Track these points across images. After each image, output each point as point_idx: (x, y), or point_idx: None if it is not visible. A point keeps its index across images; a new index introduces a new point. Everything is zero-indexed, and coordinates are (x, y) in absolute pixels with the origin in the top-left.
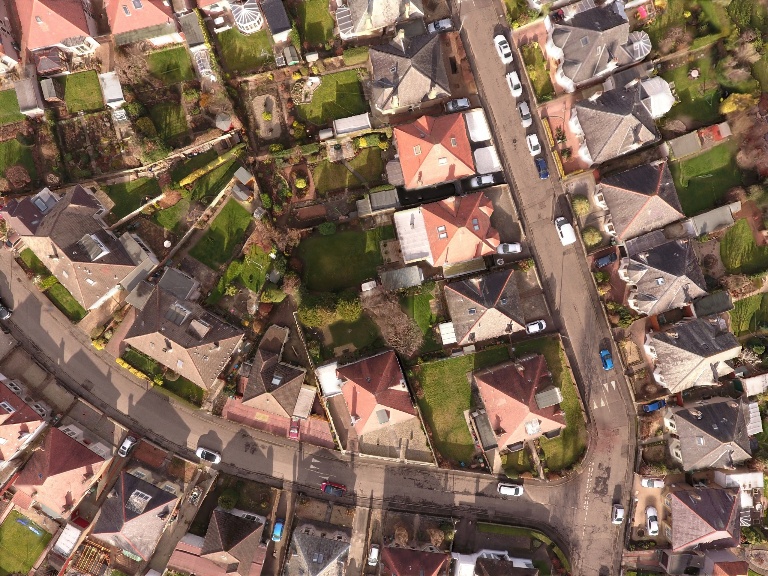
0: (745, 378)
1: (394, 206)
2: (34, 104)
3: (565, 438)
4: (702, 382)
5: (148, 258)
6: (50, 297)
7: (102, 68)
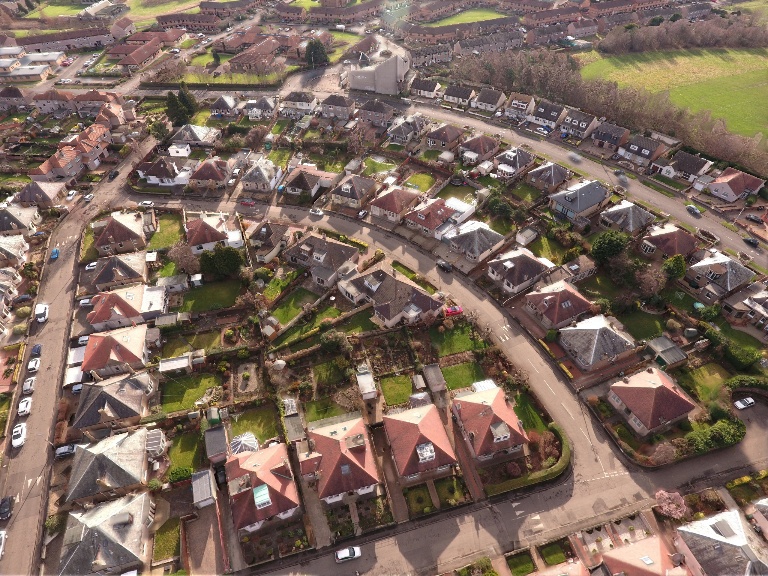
0: None
1: (161, 315)
2: (427, 369)
3: None
4: None
5: None
6: (413, 272)
7: (382, 408)
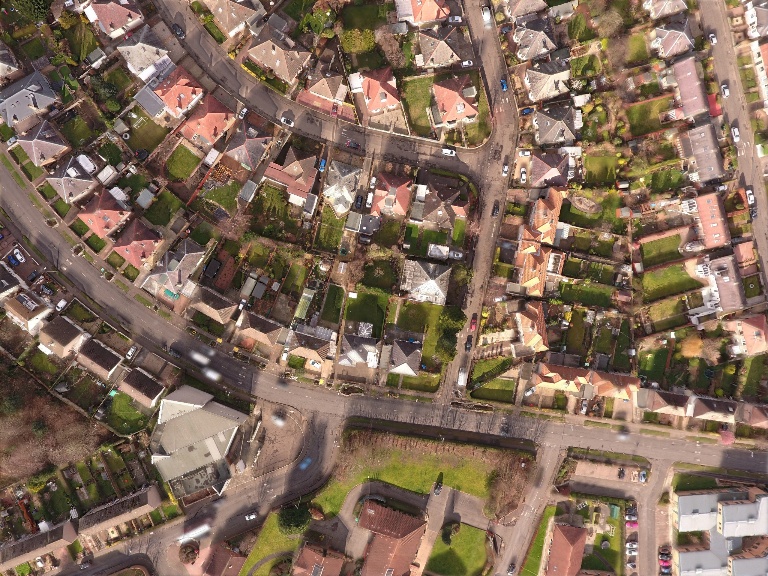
0: (575, 96)
1: None
2: None
3: (479, 127)
4: (551, 93)
5: (263, 8)
6: (207, 29)
7: None
